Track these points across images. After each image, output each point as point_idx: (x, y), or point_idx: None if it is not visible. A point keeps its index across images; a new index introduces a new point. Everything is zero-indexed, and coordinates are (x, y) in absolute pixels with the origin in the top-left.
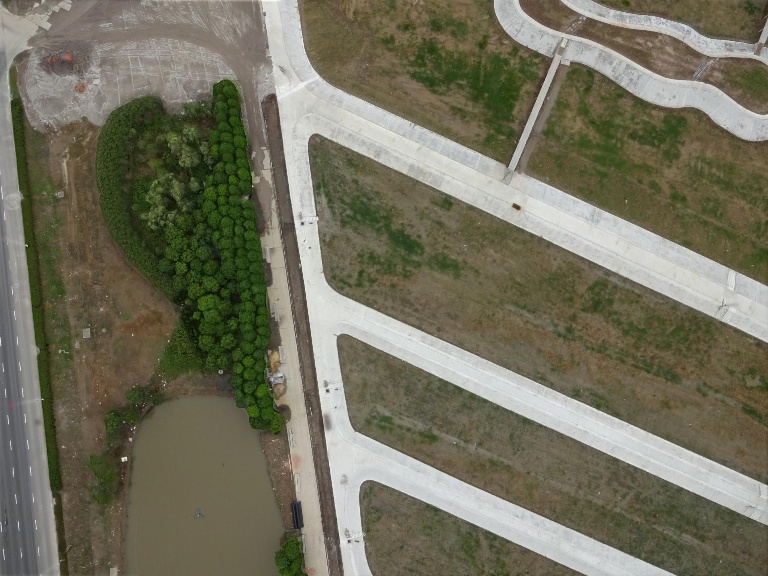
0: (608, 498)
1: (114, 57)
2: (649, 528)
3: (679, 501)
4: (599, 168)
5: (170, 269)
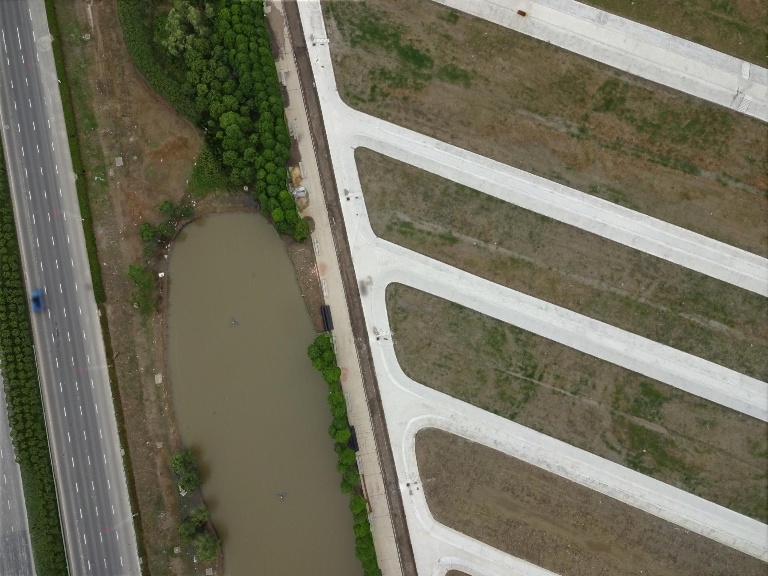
0: (632, 289)
1: None
2: (675, 316)
3: (705, 288)
4: None
5: (192, 92)
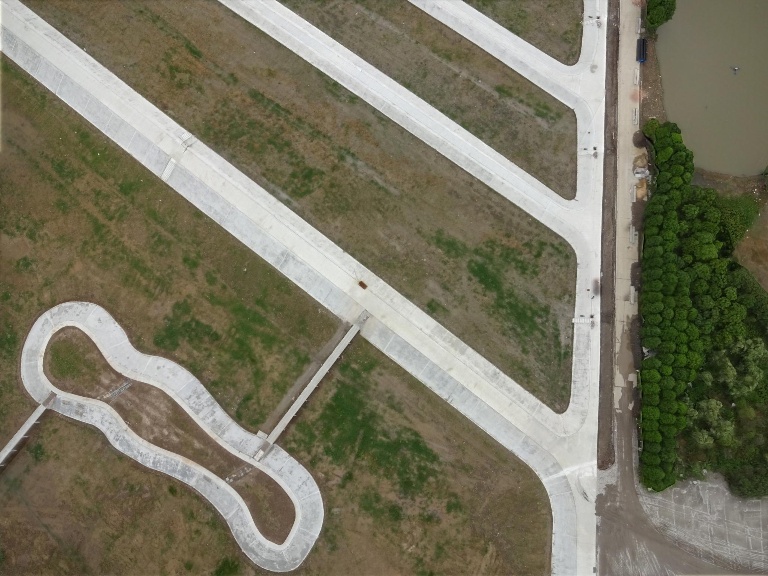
0: (350, 8)
1: None
2: None
3: None
4: (262, 311)
5: (742, 296)
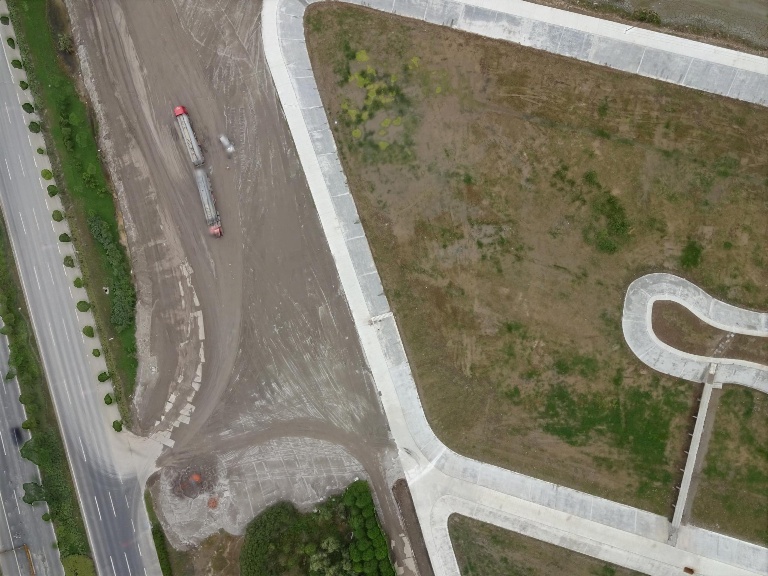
0: None
1: (239, 465)
2: None
3: None
4: None
5: None
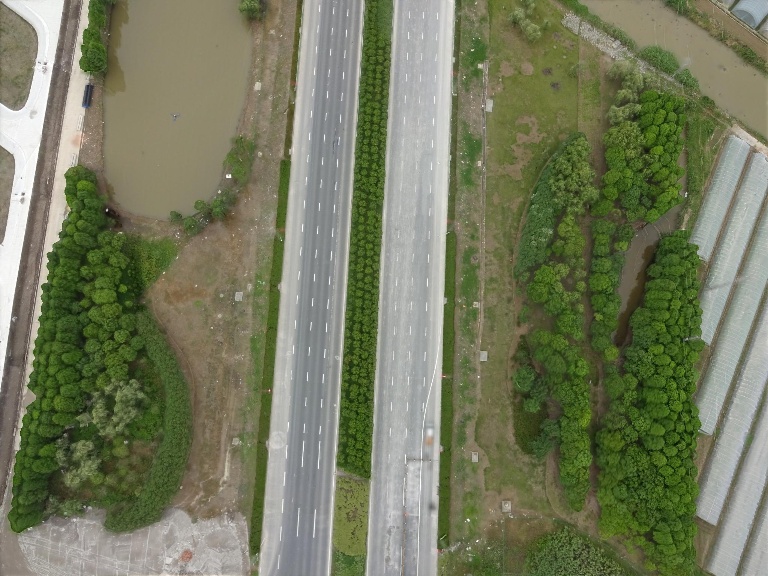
0: None
1: None
2: None
3: None
4: None
5: None
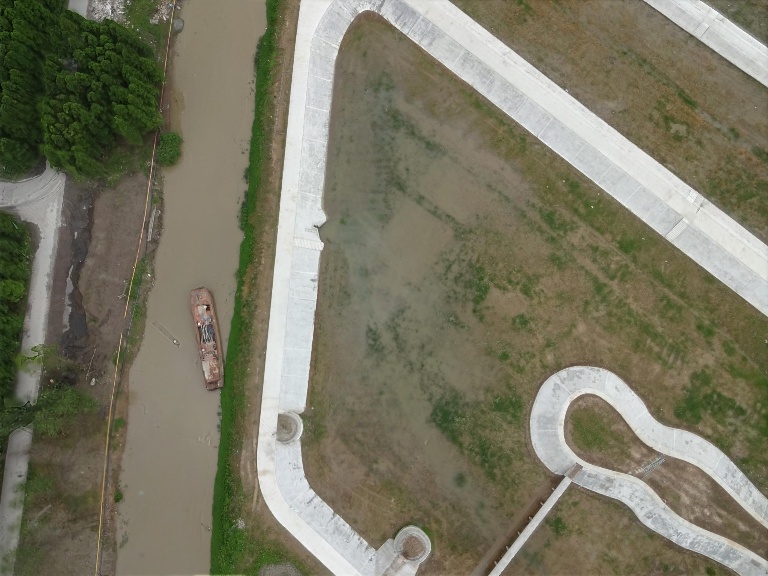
0: None
1: None
2: None
3: None
4: None
5: None
